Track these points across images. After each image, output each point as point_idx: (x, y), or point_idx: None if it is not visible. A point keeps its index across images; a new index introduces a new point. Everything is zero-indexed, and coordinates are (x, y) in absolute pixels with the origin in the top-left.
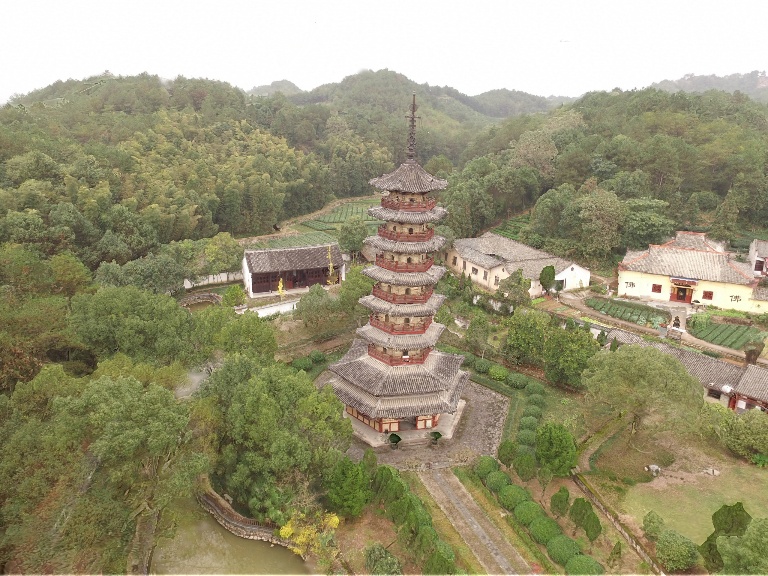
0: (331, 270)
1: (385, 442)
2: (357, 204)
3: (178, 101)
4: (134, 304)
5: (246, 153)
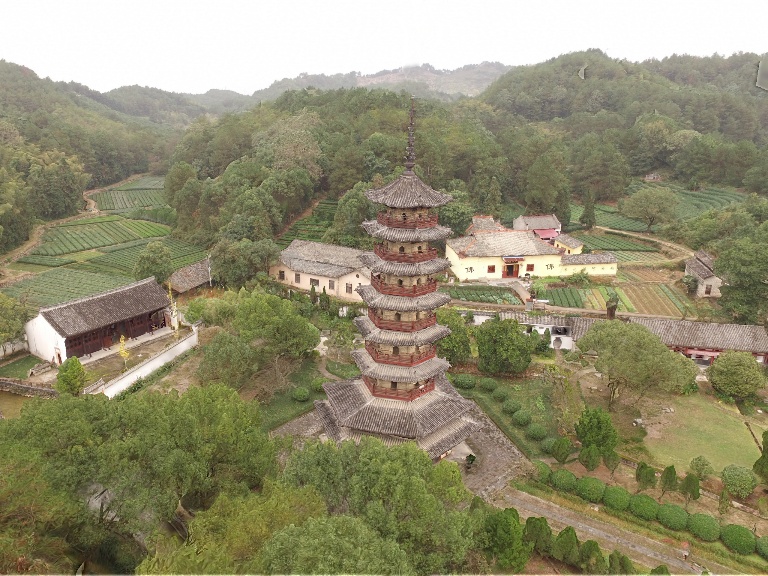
0: (174, 312)
1: None
2: (68, 227)
3: None
4: None
5: None
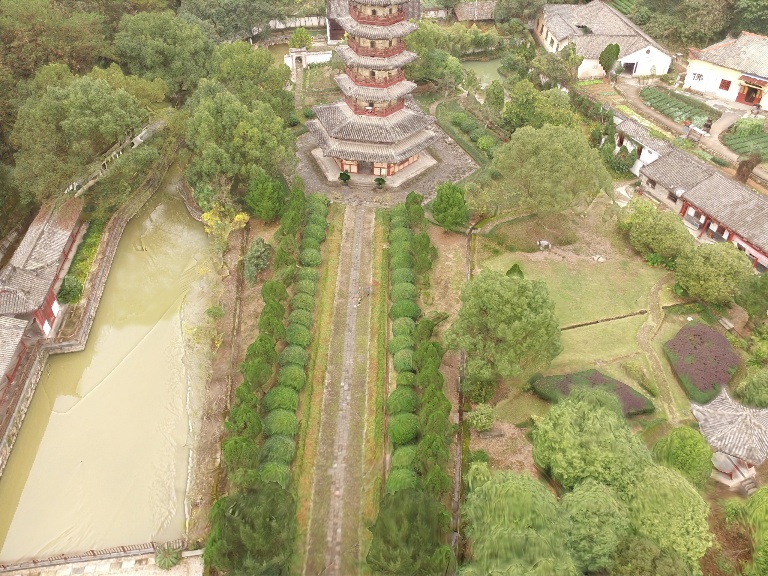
0: None
1: (338, 178)
2: None
3: None
4: (164, 29)
5: None
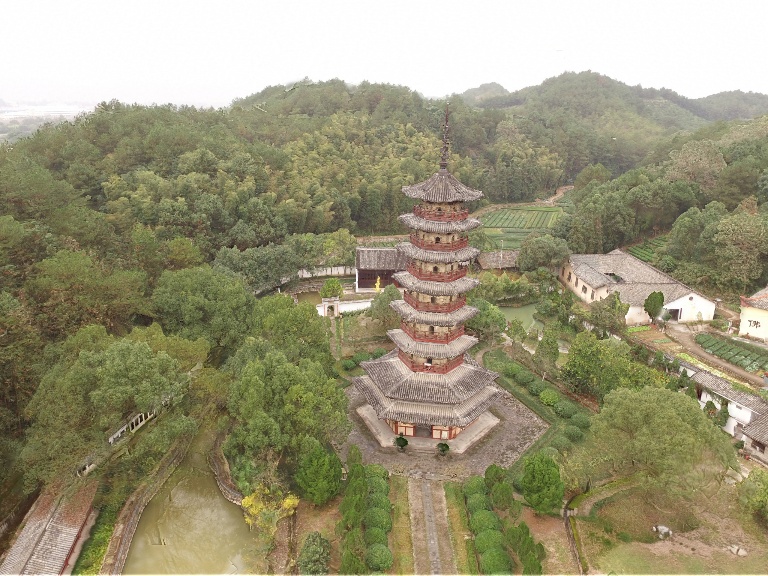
0: None
1: (394, 444)
2: (512, 210)
3: (355, 105)
4: (205, 284)
5: (403, 155)
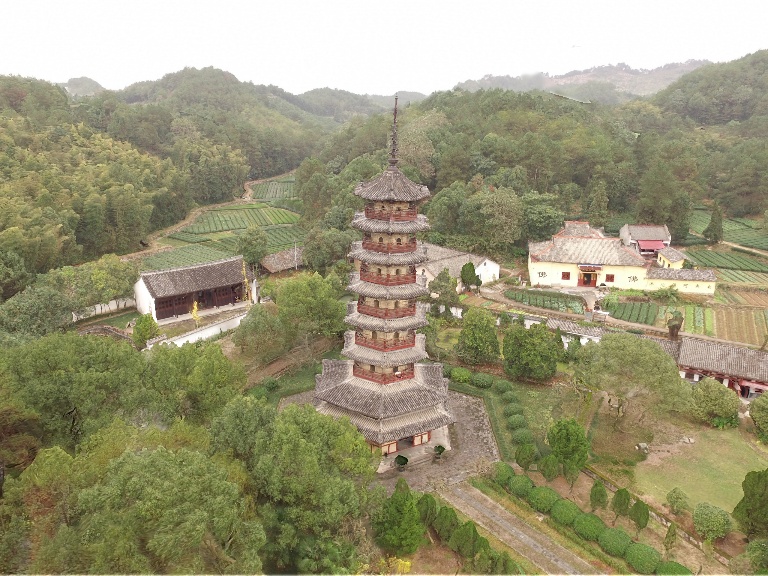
0: (246, 286)
1: (391, 466)
2: (220, 211)
3: None
4: (79, 354)
5: (92, 161)
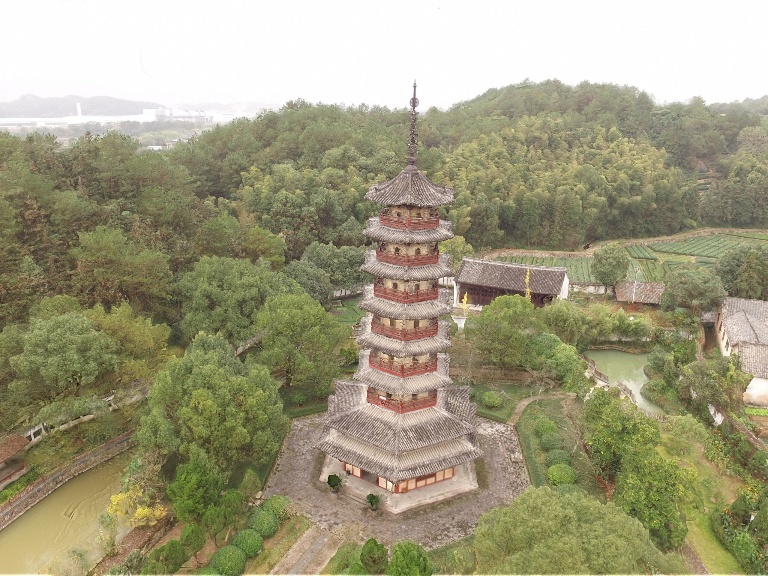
0: (527, 296)
1: None
2: (732, 237)
3: (561, 106)
4: None
5: (592, 162)
